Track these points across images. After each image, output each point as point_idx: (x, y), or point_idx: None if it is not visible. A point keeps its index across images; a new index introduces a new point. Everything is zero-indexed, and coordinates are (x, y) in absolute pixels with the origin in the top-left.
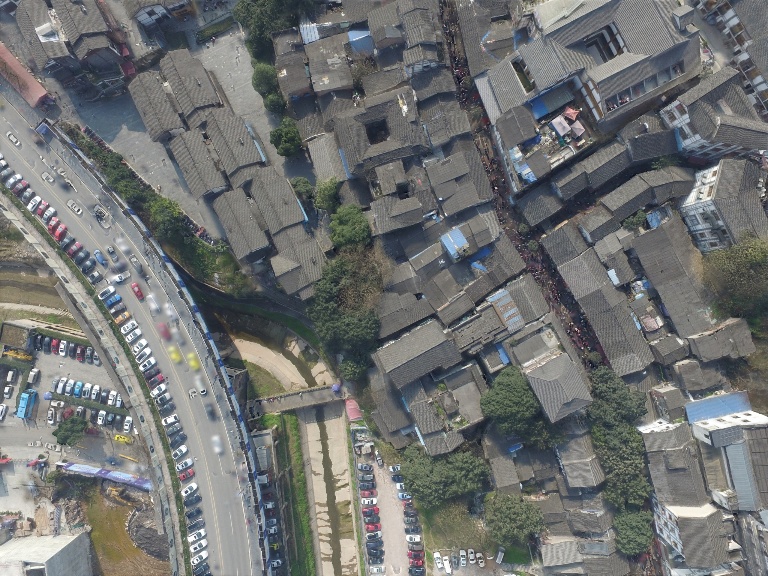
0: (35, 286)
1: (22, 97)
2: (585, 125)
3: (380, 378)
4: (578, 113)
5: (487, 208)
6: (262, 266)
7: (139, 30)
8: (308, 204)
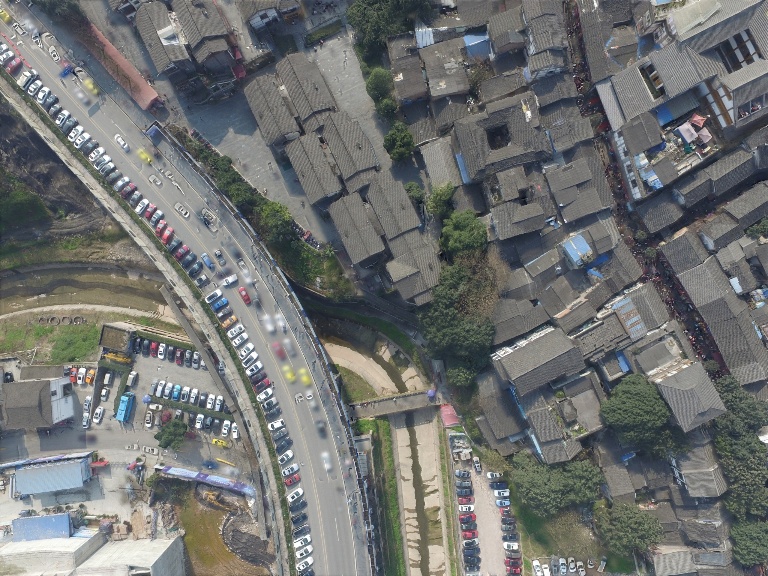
0: (125, 288)
1: (130, 99)
2: (711, 132)
3: (489, 385)
4: (705, 120)
5: (606, 215)
6: (368, 271)
7: (249, 33)
8: (415, 209)
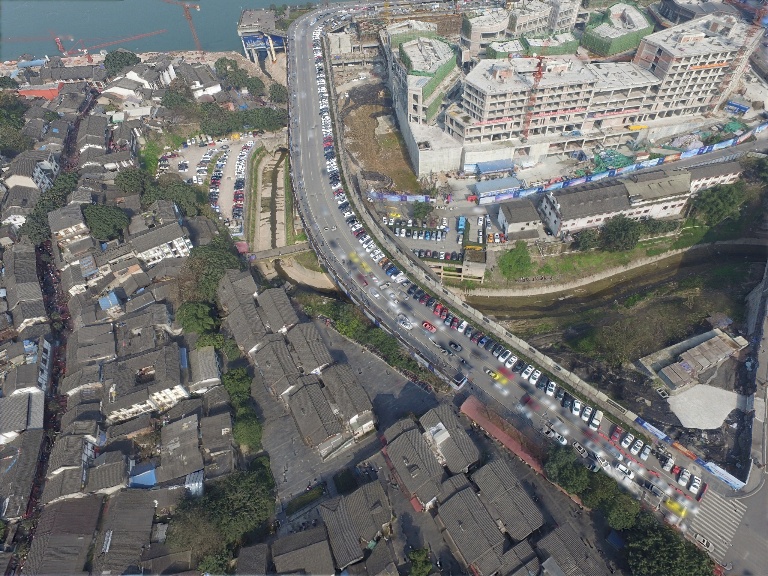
0: (496, 309)
1: None
2: None
3: (202, 243)
4: None
5: None
6: None
7: None
8: None
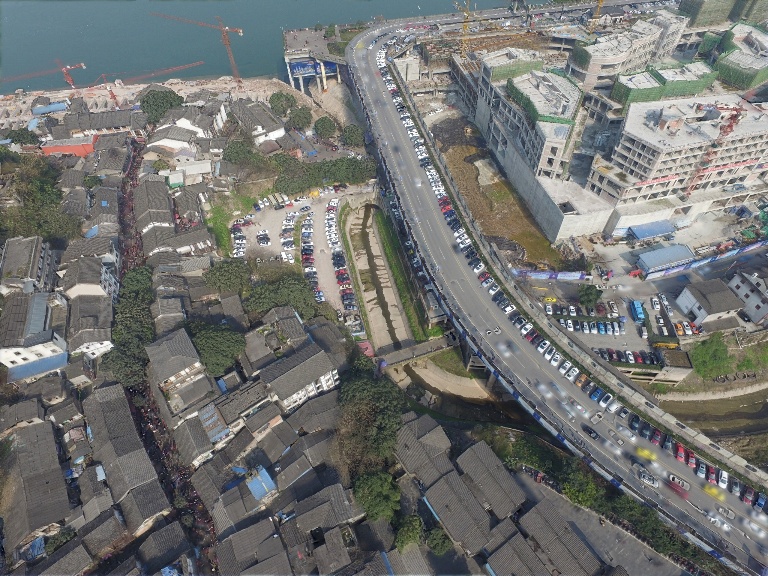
0: (697, 419)
1: None
2: None
3: None
4: None
5: (225, 536)
6: None
7: None
8: None
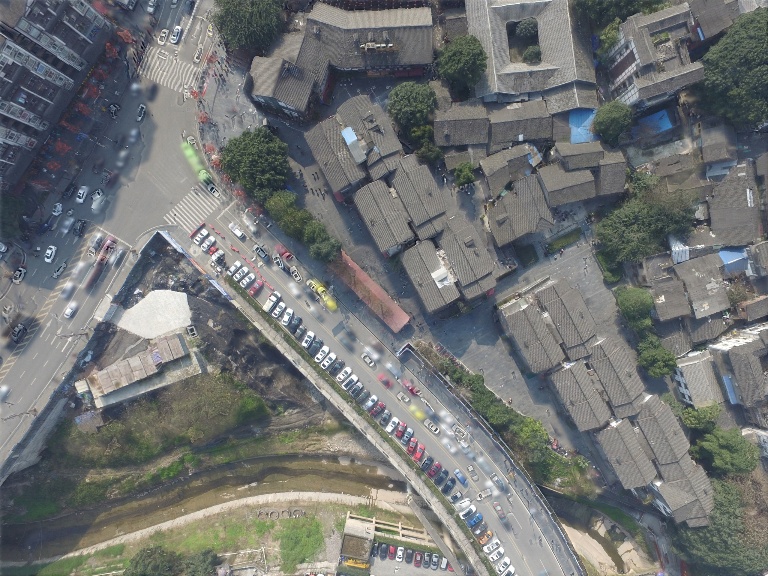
0: (336, 474)
1: (376, 318)
2: None
3: None
4: None
5: None
6: None
7: (495, 249)
8: None
